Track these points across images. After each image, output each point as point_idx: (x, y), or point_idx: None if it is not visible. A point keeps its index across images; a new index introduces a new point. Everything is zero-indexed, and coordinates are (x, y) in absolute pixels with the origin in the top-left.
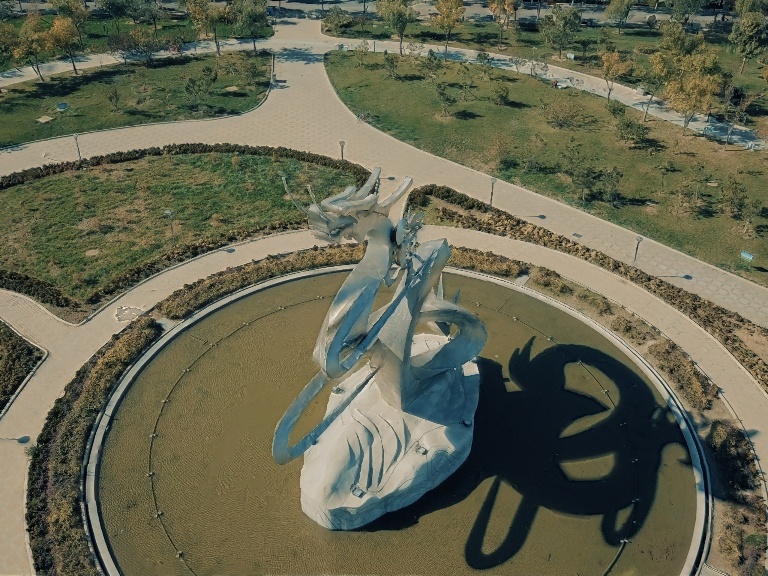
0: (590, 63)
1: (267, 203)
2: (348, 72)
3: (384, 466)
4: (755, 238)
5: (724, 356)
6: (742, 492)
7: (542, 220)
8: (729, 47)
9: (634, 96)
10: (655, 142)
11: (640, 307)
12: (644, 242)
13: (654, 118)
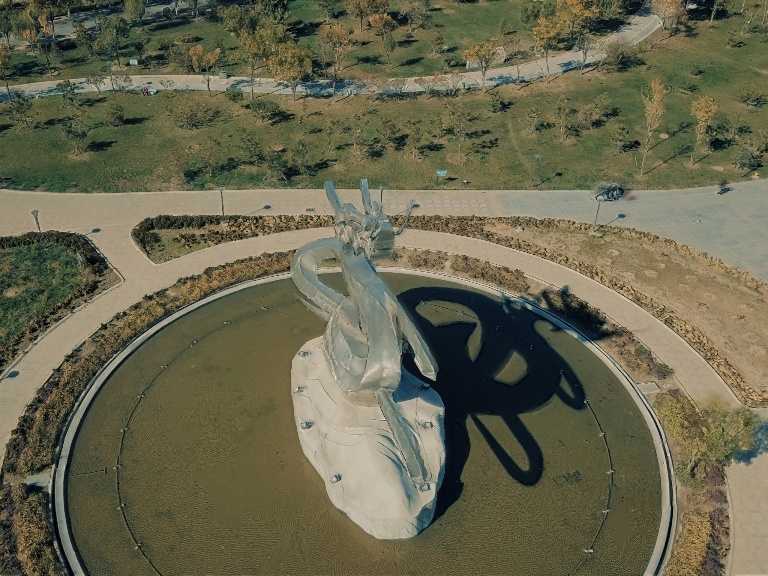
0: (152, 64)
1: None
2: None
3: None
4: (425, 159)
5: (497, 248)
6: (603, 328)
7: (270, 210)
8: None
9: (221, 81)
10: (283, 113)
11: (413, 242)
12: None
13: (258, 94)
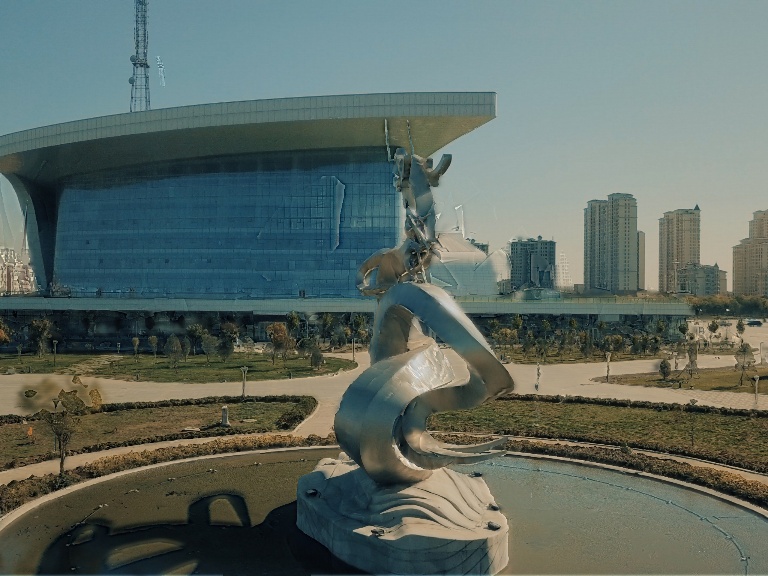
0: None
1: None
2: None
3: None
4: None
5: None
6: None
7: None
8: None
9: None
10: None
11: None
12: None
13: None
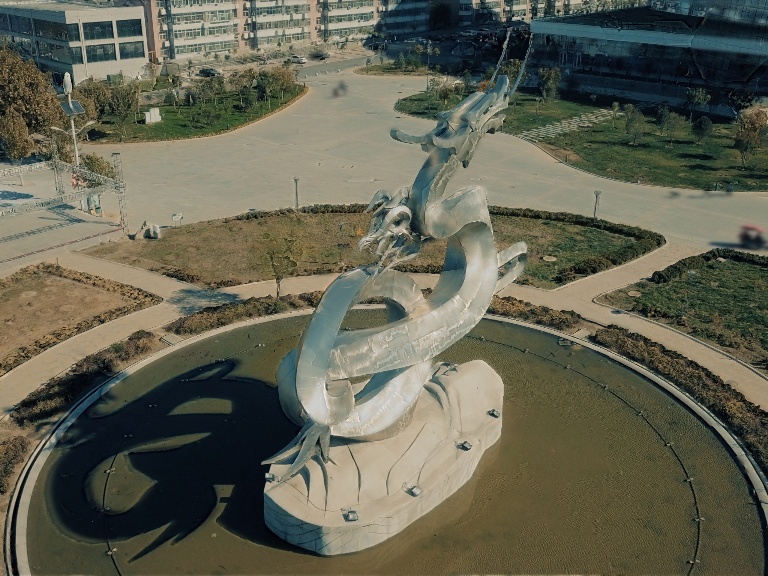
0: None
1: None
2: None
3: None
4: None
5: None
6: None
7: None
8: None
9: None
10: None
11: None
12: None
13: None
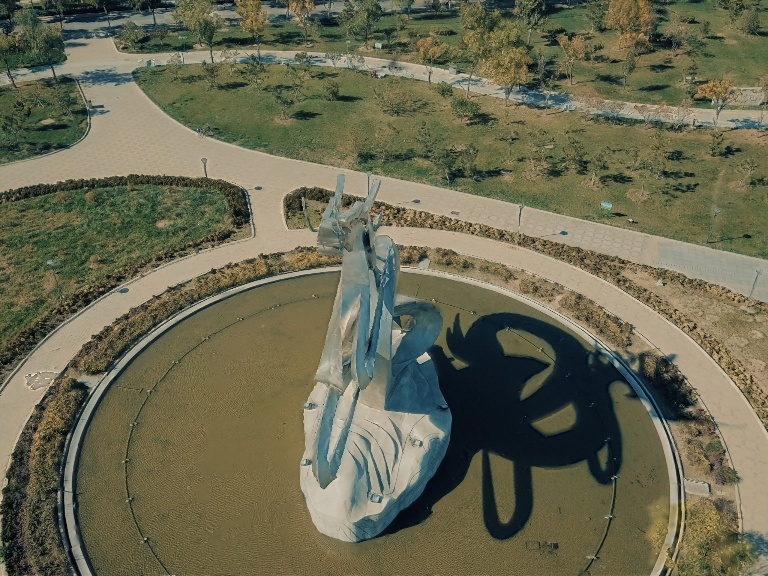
0: (396, 50)
1: (142, 235)
2: (166, 88)
3: (388, 467)
4: (603, 188)
5: (622, 296)
6: (686, 409)
7: (418, 204)
8: (509, 21)
9: (448, 76)
10: (486, 116)
11: (537, 268)
12: (515, 208)
13: (475, 94)
